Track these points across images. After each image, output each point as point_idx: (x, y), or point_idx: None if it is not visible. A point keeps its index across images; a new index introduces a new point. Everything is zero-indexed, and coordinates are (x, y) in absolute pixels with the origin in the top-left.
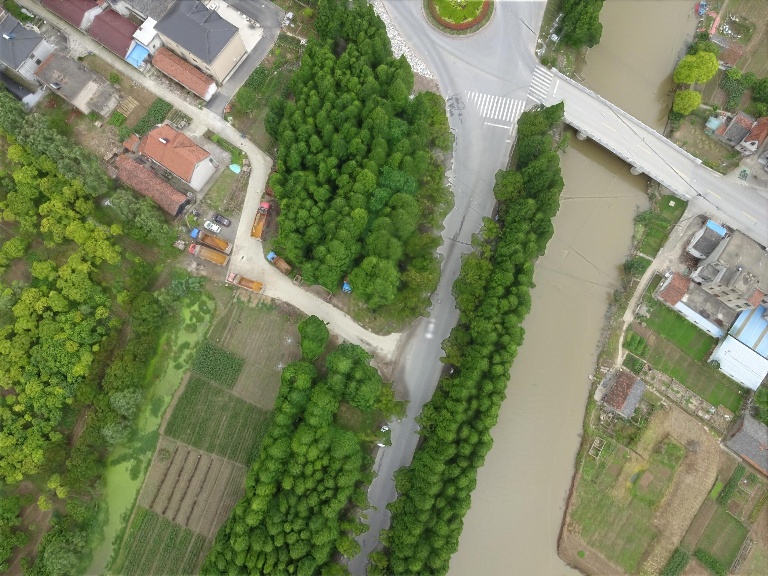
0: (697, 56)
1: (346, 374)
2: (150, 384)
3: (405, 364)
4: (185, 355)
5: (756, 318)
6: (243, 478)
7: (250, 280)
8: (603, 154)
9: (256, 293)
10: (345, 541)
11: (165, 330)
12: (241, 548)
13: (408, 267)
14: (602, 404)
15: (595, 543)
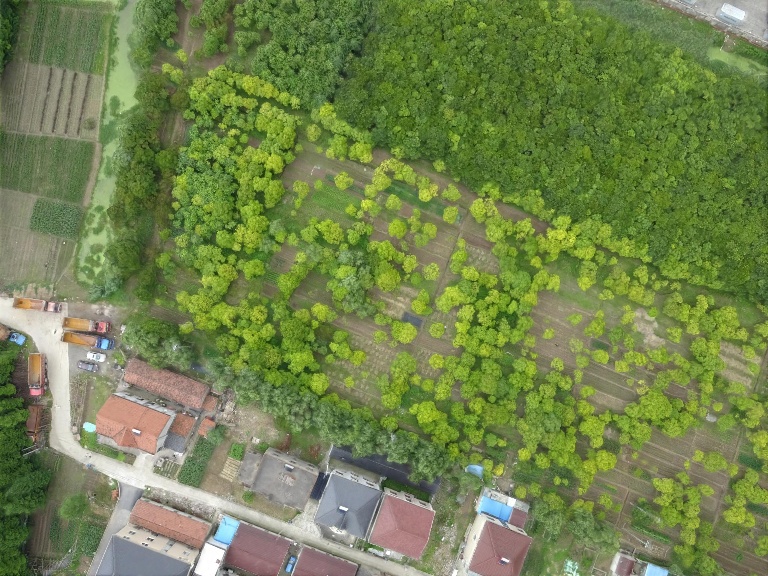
0: None
1: None
2: None
3: None
4: (95, 221)
5: None
6: (6, 121)
7: None
8: None
9: None
10: None
11: None
12: None
13: None
14: None
15: None
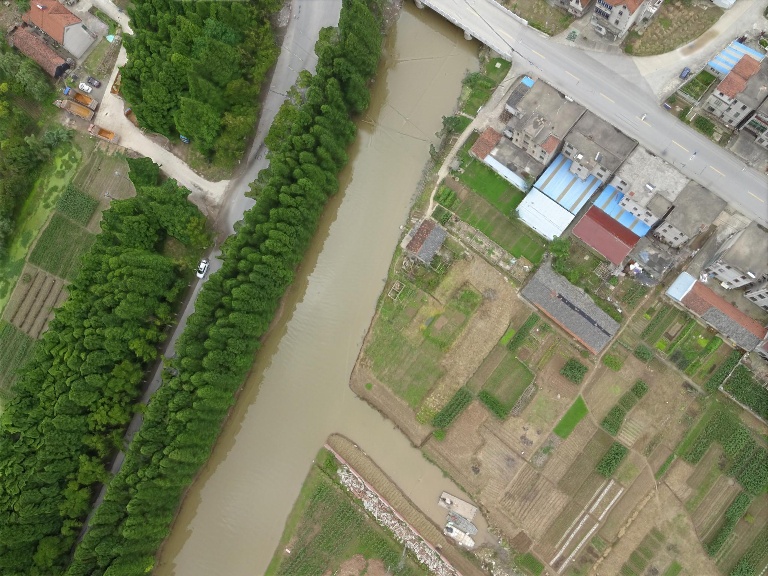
0: None
1: (154, 199)
2: (23, 220)
3: (230, 207)
4: (53, 197)
5: (563, 172)
6: None
7: (108, 131)
8: (439, 21)
9: (113, 144)
10: (135, 340)
11: (40, 175)
12: (49, 339)
13: (226, 112)
14: (407, 251)
15: (384, 378)
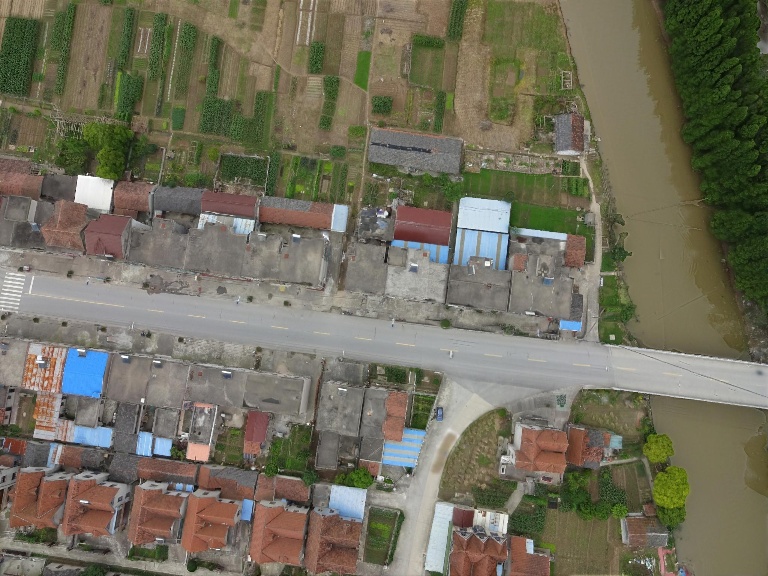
0: (684, 497)
1: None
2: None
3: None
4: None
5: None
6: None
7: None
8: None
9: None
10: None
11: None
12: None
13: None
14: None
15: (528, 7)
